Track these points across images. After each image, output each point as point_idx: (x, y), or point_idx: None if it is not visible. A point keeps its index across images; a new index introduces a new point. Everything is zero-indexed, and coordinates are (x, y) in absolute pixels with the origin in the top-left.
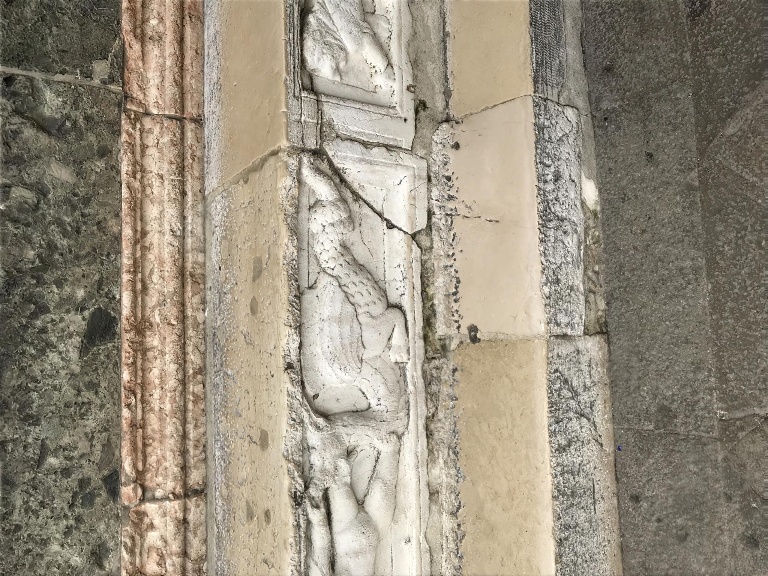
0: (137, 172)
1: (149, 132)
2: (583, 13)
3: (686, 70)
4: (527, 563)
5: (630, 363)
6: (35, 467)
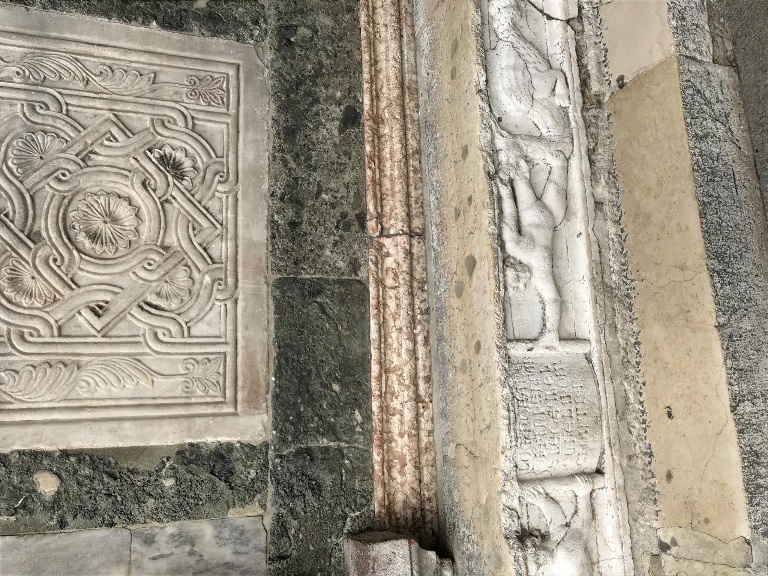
0: (370, 22)
1: None
2: None
3: None
4: (677, 226)
5: (757, 78)
6: (314, 198)
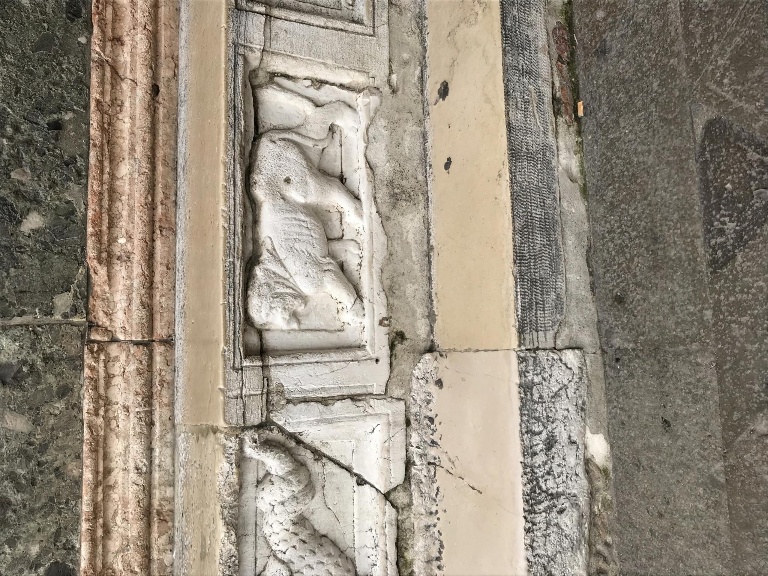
0: (100, 407)
1: (115, 360)
2: (590, 226)
3: (707, 333)
4: None
5: None
6: None
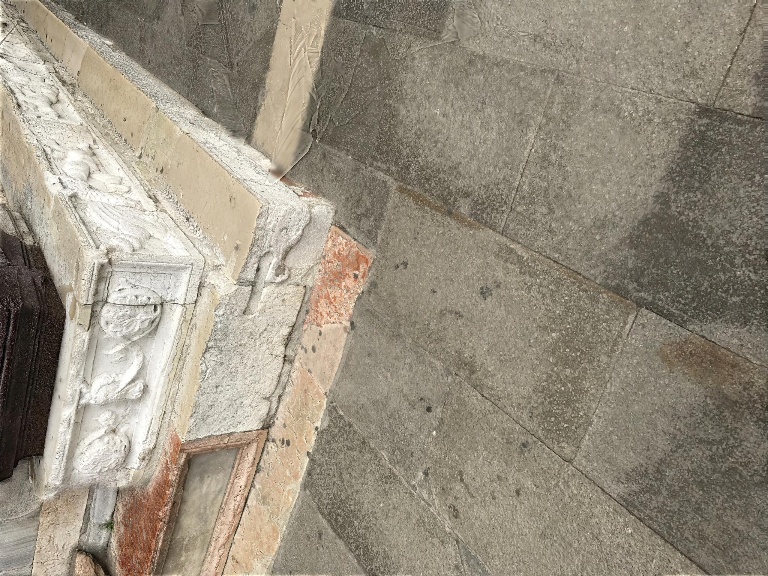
0: None
1: None
2: None
3: None
4: None
5: None
6: None
